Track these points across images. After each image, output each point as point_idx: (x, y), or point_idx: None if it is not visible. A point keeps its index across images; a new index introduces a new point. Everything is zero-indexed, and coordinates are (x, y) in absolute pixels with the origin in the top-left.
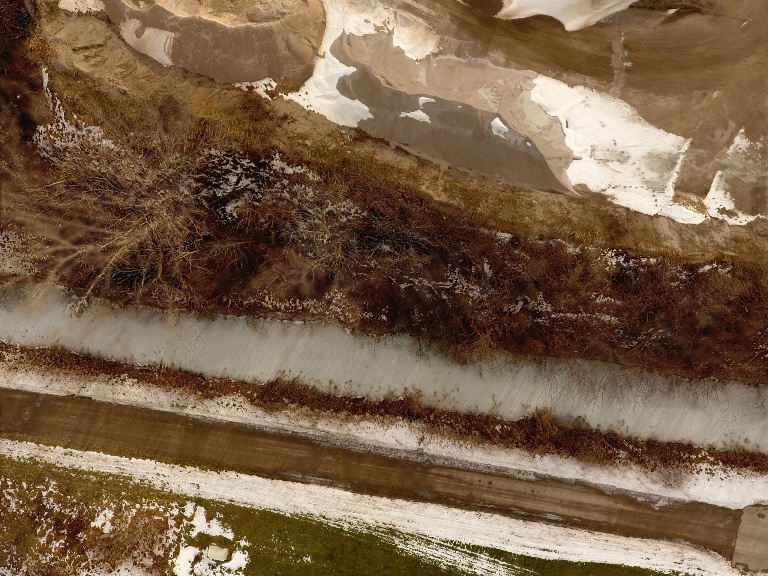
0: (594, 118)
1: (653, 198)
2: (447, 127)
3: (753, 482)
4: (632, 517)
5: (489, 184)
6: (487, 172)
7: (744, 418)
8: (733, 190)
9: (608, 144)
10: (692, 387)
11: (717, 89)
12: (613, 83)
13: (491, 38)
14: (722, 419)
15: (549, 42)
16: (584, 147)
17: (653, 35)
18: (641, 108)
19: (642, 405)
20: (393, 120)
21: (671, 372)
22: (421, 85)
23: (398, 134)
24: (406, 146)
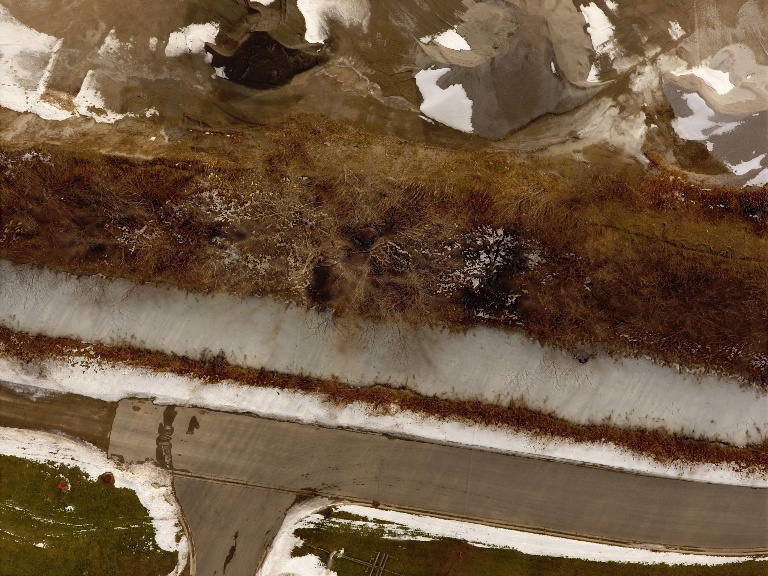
0: None
1: (25, 96)
2: None
3: (125, 375)
4: (10, 408)
5: None
6: None
7: (131, 315)
8: (104, 89)
9: None
10: (81, 284)
11: None
12: None
13: None
14: (109, 315)
15: None
16: None
17: None
18: (13, 8)
19: (33, 301)
20: None
21: (61, 269)
22: None
23: None
24: None
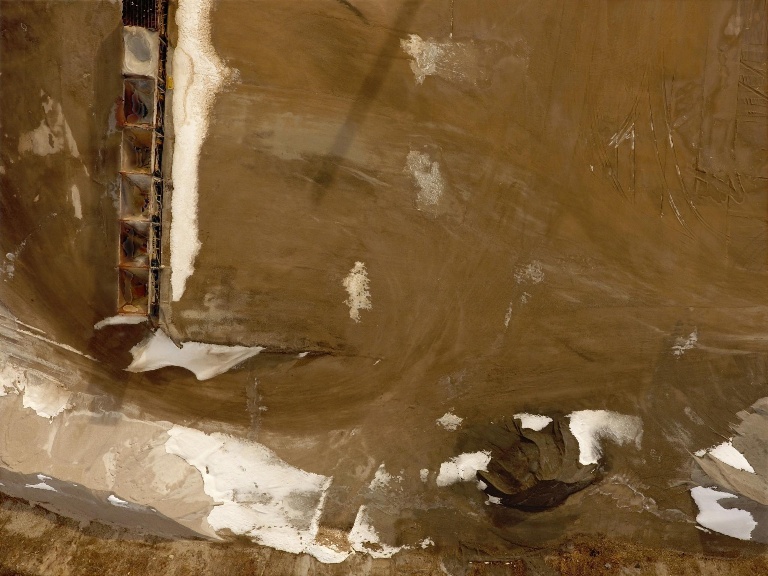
0: (233, 463)
1: (298, 536)
2: (73, 496)
3: None
4: None
5: (130, 537)
6: (128, 524)
7: None
8: (377, 523)
9: (250, 487)
10: None
11: (354, 427)
12: (250, 428)
13: (124, 391)
14: None
15: (182, 392)
16: (225, 492)
17: (286, 379)
18: (280, 450)
19: None
20: (22, 489)
21: None
22: (44, 456)
23: (33, 496)
24: (46, 504)
